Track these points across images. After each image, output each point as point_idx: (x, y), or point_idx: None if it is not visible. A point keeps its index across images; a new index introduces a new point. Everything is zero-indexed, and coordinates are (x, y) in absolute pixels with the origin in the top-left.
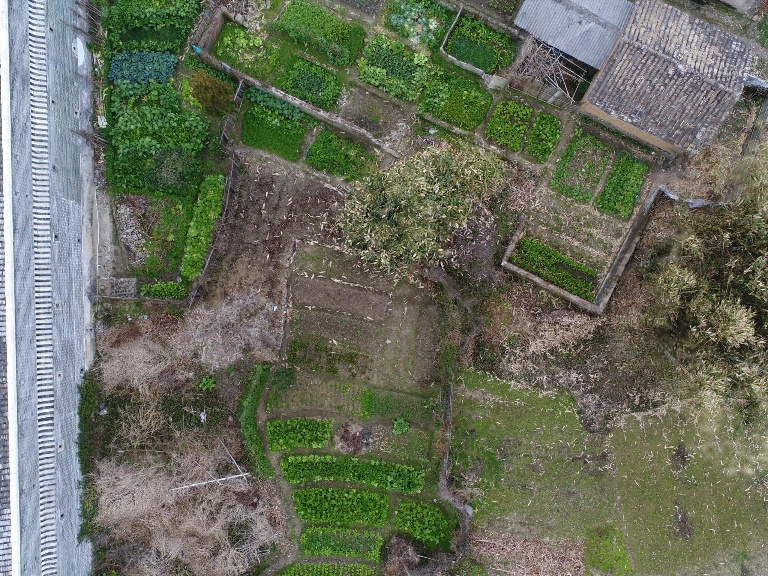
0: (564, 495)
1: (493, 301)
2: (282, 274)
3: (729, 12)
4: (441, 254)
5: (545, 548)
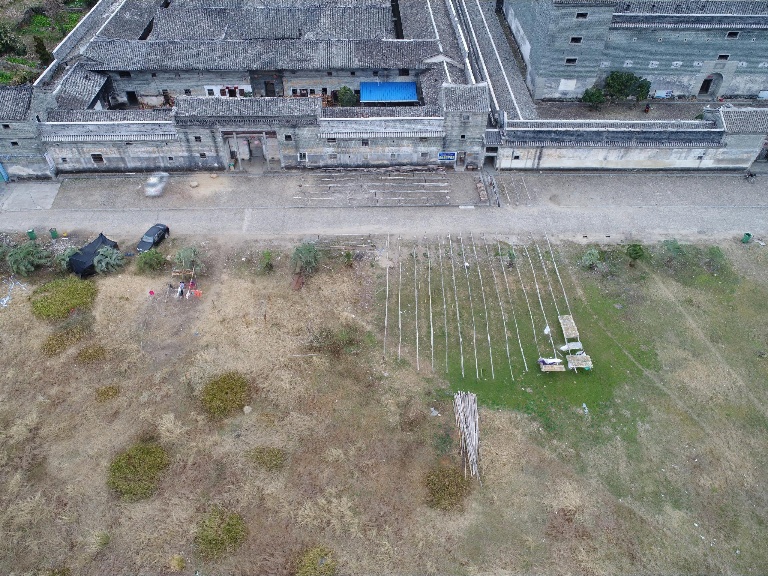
0: None
1: None
2: (54, 48)
3: None
4: None
5: (8, 16)
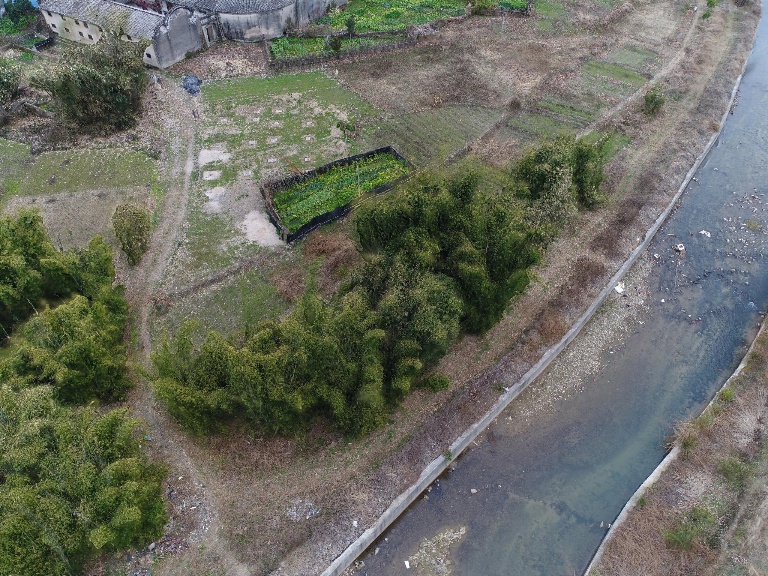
0: (6, 169)
1: (20, 120)
2: None
3: (158, 70)
4: (6, 104)
5: None
